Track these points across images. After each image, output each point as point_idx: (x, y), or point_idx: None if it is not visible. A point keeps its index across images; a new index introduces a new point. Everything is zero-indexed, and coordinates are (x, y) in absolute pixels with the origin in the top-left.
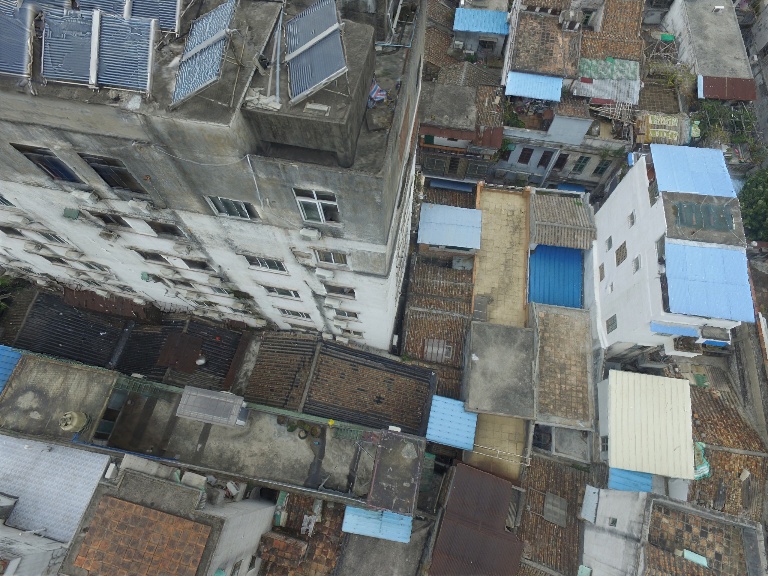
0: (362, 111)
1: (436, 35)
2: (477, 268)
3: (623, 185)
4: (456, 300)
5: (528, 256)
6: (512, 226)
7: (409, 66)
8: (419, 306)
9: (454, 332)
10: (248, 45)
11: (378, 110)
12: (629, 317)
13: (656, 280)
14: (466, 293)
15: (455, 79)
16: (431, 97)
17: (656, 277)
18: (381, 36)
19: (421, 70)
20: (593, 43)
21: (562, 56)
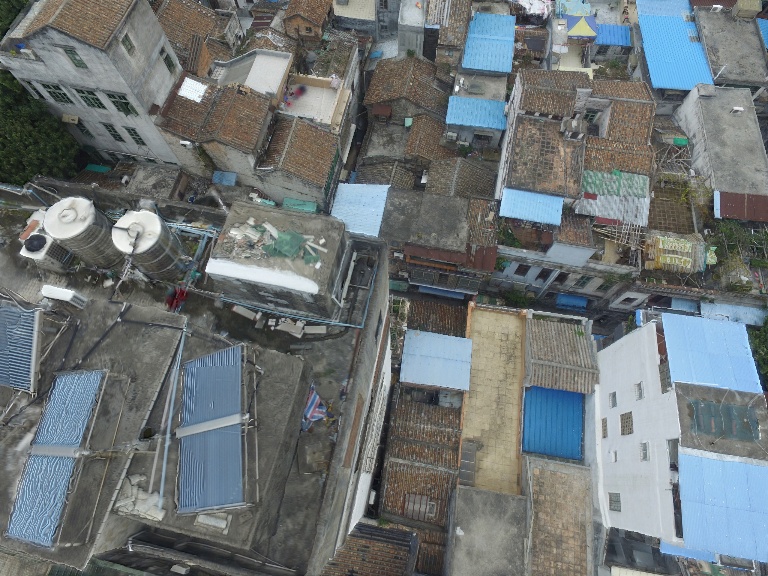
0: (289, 459)
1: (428, 123)
2: (466, 405)
3: (630, 341)
4: (442, 446)
5: (523, 395)
6: (506, 354)
7: (354, 387)
8: (400, 456)
9: (438, 487)
10: (128, 410)
11: (314, 440)
12: (635, 511)
13: (667, 492)
14: (453, 440)
15: (447, 177)
16: (418, 210)
17: (667, 488)
18: (325, 315)
19: (385, 306)
20: (598, 154)
21: (563, 171)
